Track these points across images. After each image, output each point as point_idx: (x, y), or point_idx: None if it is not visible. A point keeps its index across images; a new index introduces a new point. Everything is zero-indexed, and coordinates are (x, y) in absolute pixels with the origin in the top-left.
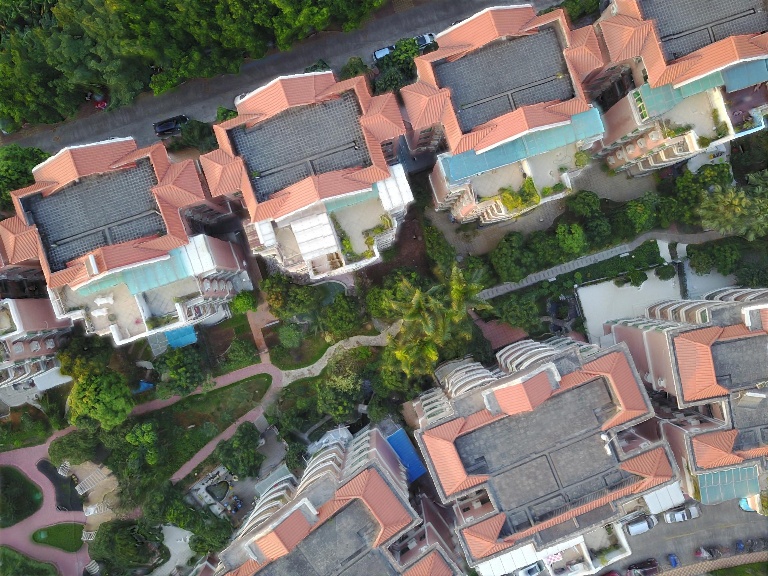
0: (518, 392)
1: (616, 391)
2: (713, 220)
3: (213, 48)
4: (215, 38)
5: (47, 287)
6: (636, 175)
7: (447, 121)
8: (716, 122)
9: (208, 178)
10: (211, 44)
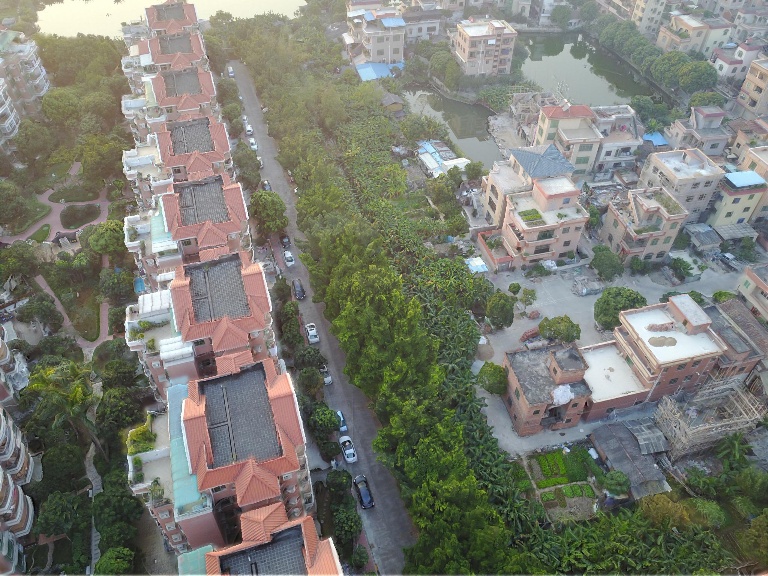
0: None
1: None
2: None
3: None
4: None
5: None
6: None
7: None
8: None
9: None
10: None
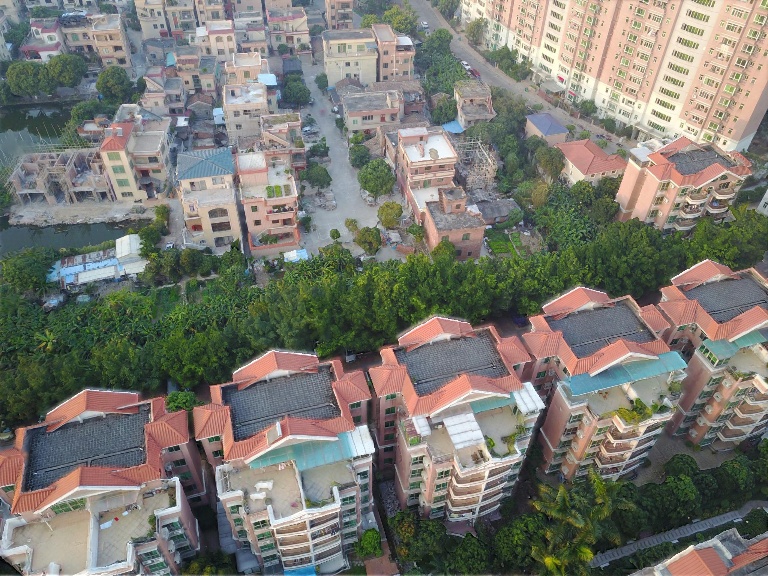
0: (693, 561)
1: None
2: None
3: (364, 333)
4: (369, 323)
5: (216, 468)
6: (719, 450)
7: (563, 353)
8: None
9: (375, 383)
10: (362, 331)
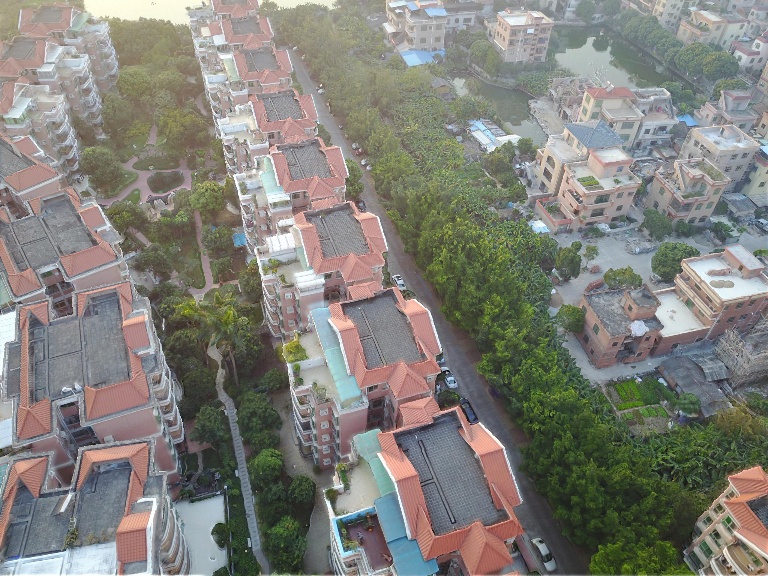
0: None
1: None
2: None
3: None
4: None
5: None
6: None
7: None
8: None
9: None
10: None
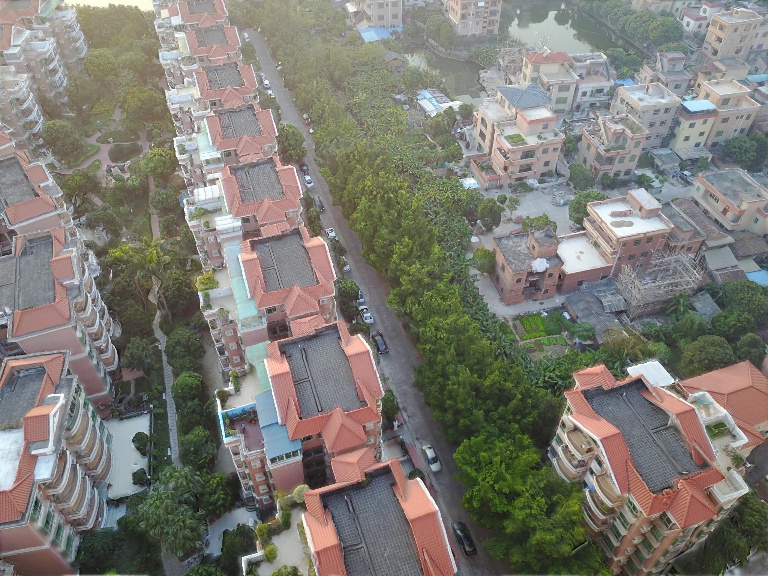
0: None
1: None
2: None
3: None
4: None
5: None
6: None
7: None
8: None
9: None
10: None
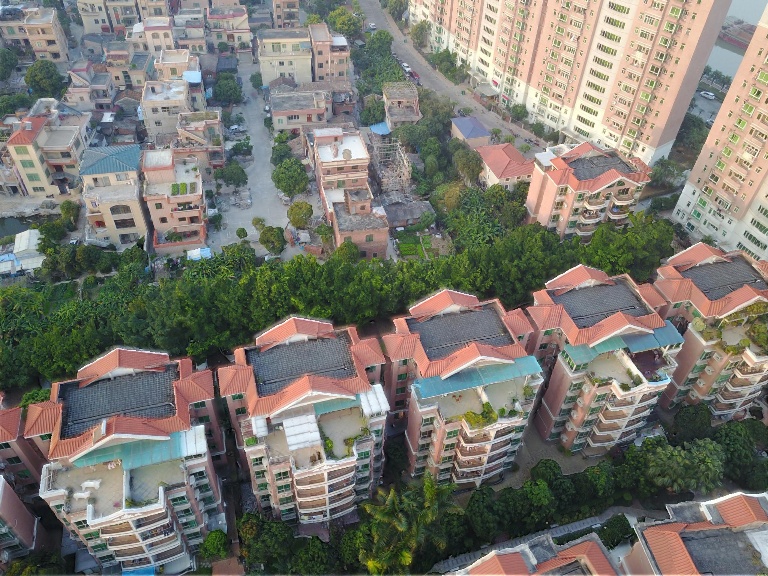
0: (493, 566)
1: (595, 573)
2: (663, 475)
3: (241, 332)
4: (245, 322)
5: (44, 466)
6: (590, 455)
7: (418, 355)
8: (632, 377)
9: (221, 383)
10: (240, 331)
